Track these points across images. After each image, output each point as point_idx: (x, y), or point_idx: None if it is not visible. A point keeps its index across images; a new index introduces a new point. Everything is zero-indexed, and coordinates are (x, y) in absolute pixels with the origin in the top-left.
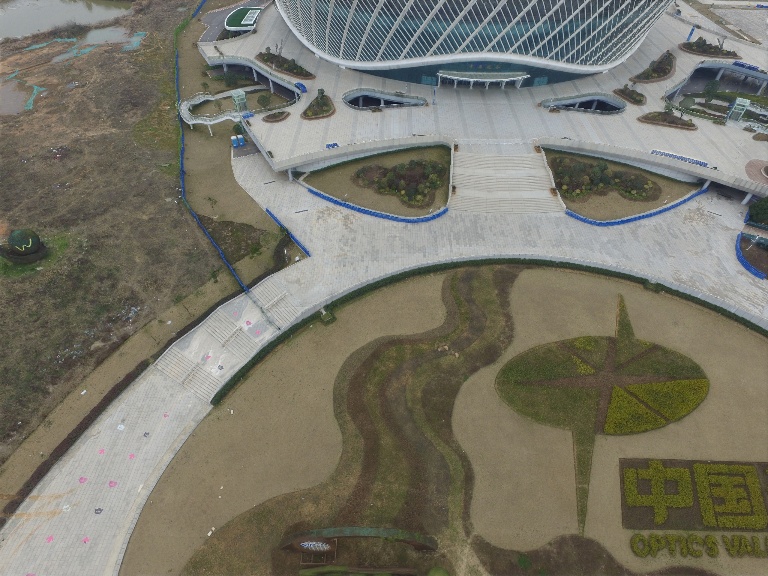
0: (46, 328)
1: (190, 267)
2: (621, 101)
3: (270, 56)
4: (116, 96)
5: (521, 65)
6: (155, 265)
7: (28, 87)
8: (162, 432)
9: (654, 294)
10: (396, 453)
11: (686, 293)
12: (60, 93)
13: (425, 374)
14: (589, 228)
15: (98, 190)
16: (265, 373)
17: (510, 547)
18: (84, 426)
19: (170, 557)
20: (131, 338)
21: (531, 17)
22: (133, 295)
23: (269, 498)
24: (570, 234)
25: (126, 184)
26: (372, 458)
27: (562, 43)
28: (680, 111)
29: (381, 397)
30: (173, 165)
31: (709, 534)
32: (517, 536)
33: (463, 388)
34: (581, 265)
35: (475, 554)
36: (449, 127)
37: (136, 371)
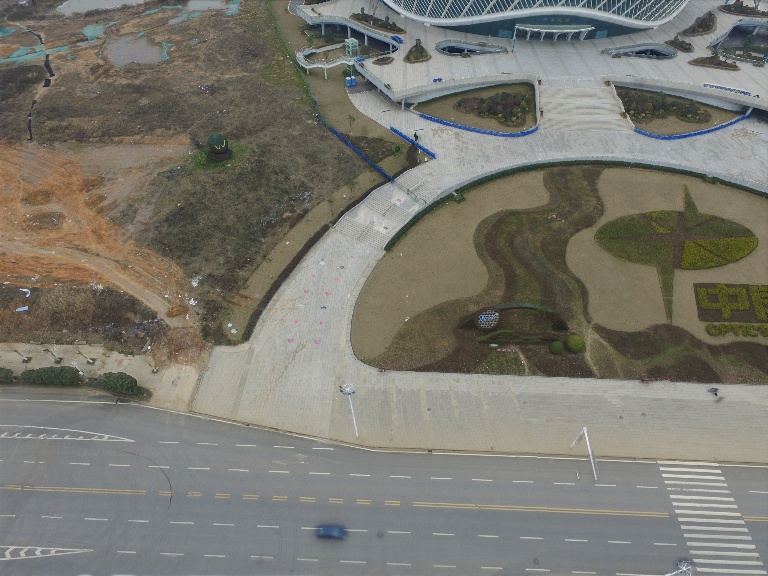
0: (247, 203)
1: (341, 166)
2: (672, 49)
3: (364, 16)
4: (236, 49)
5: (587, 18)
6: (314, 165)
7: (158, 43)
8: (353, 266)
9: (711, 185)
10: (528, 278)
11: (737, 183)
12: (187, 47)
13: (541, 232)
14: (655, 141)
15: (252, 114)
16: (420, 232)
17: (620, 330)
18: (296, 261)
19: (383, 332)
20: (310, 211)
21: None
22: (304, 184)
23: (443, 302)
24: (640, 145)
25: (272, 111)
26: (512, 281)
27: None
28: (724, 57)
29: (511, 246)
30: (304, 98)
31: (762, 325)
32: (624, 324)
33: (571, 241)
34: (652, 165)
35: (596, 333)
36: (530, 68)
37: (322, 230)
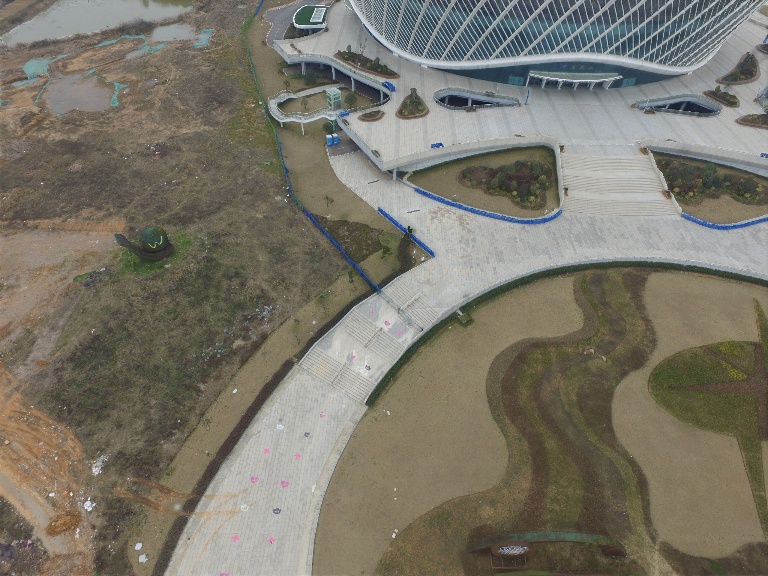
0: (186, 326)
1: (314, 266)
2: (715, 103)
3: (351, 55)
4: (199, 93)
5: (615, 66)
6: (279, 264)
7: (109, 84)
8: (322, 432)
9: None
10: (564, 457)
11: None
12: (142, 90)
13: (576, 377)
14: (709, 231)
15: (207, 188)
16: (414, 374)
17: (699, 554)
18: (244, 425)
19: (359, 559)
20: (270, 337)
21: (636, 17)
22: (264, 294)
23: (445, 501)
24: (691, 237)
25: (233, 182)
26: (541, 462)
27: (660, 44)
28: None
29: (537, 400)
30: (274, 163)
31: None
32: (704, 543)
33: (617, 392)
34: (710, 269)
35: (666, 561)
36: (548, 128)
37: (283, 370)
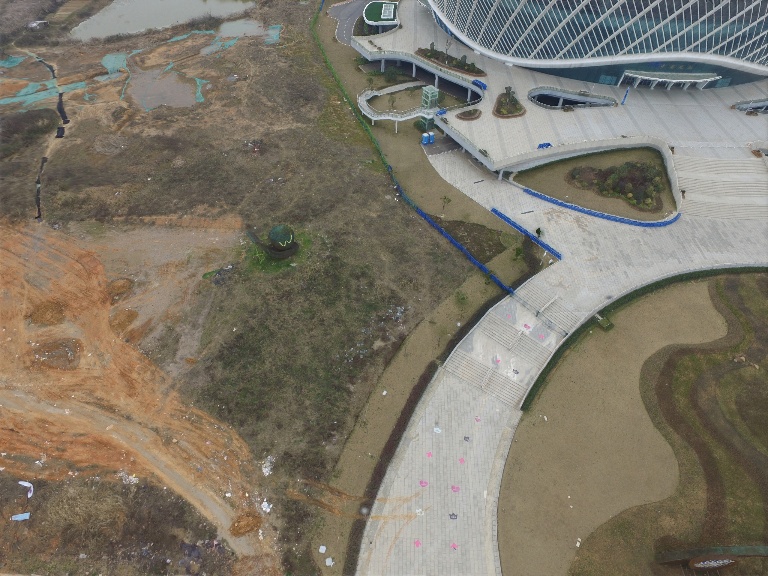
0: (324, 326)
1: (439, 267)
2: None
3: (434, 52)
4: (283, 90)
5: (715, 66)
6: (403, 264)
7: (190, 79)
8: (482, 437)
9: None
10: (735, 467)
11: None
12: (225, 86)
13: (731, 386)
14: None
15: (315, 186)
16: (563, 379)
17: None
18: (403, 428)
19: (548, 567)
20: (408, 338)
21: (749, 17)
22: (394, 294)
23: (623, 510)
24: None
25: (340, 180)
26: (713, 472)
27: (765, 44)
28: None
29: (696, 408)
30: (376, 162)
31: None
32: None
33: None
34: None
35: None
36: (651, 128)
37: (429, 373)
